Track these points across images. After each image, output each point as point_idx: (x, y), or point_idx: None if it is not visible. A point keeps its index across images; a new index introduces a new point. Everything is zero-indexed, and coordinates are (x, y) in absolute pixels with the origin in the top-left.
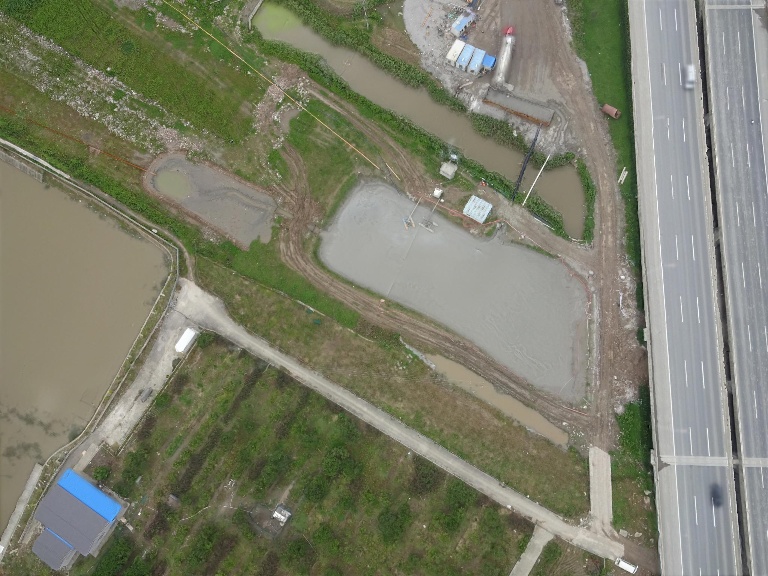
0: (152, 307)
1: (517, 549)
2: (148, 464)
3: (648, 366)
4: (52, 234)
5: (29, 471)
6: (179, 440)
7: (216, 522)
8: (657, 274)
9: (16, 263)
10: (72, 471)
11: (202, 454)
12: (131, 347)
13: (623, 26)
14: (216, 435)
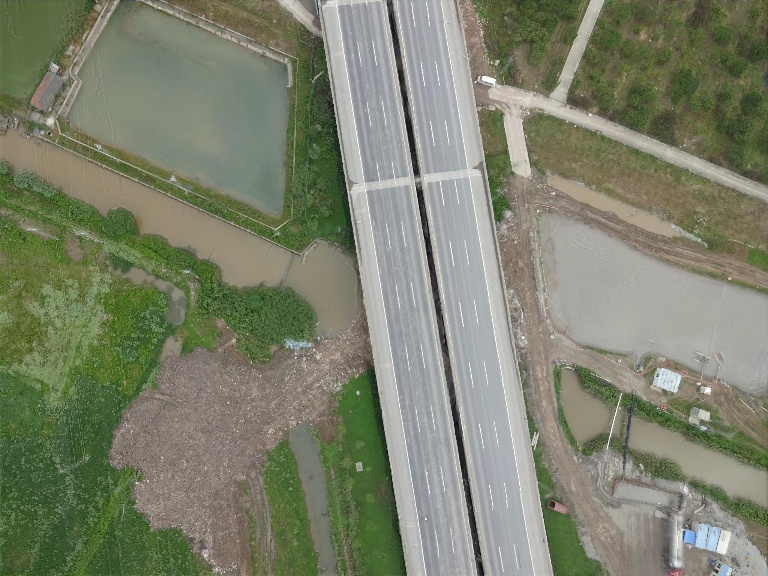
0: None
1: None
2: None
3: None
4: None
5: None
6: None
7: None
8: (501, 343)
9: None
10: None
11: None
12: None
13: None
14: None
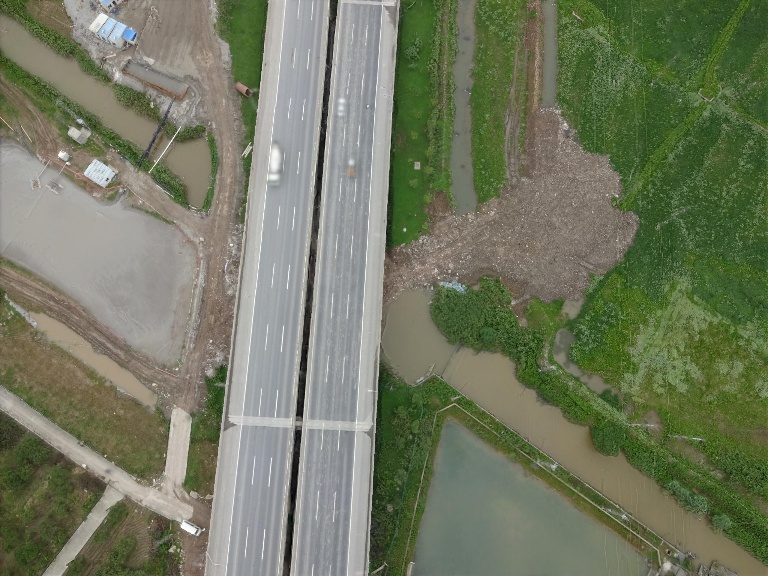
0: None
1: None
2: None
3: None
4: None
5: None
6: None
7: None
8: (256, 242)
9: None
10: None
11: None
12: None
13: (264, 13)
14: None
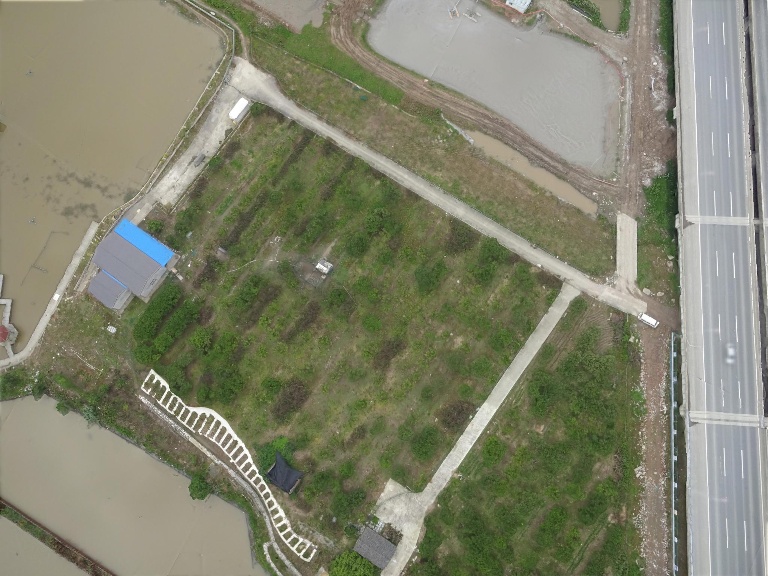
0: (207, 84)
1: (545, 303)
2: (199, 221)
3: (677, 138)
4: (115, 18)
5: (86, 229)
6: (229, 200)
7: (261, 274)
8: (688, 56)
9: (80, 41)
10: (128, 223)
11: (251, 212)
12: (186, 119)
13: None
14: (264, 195)
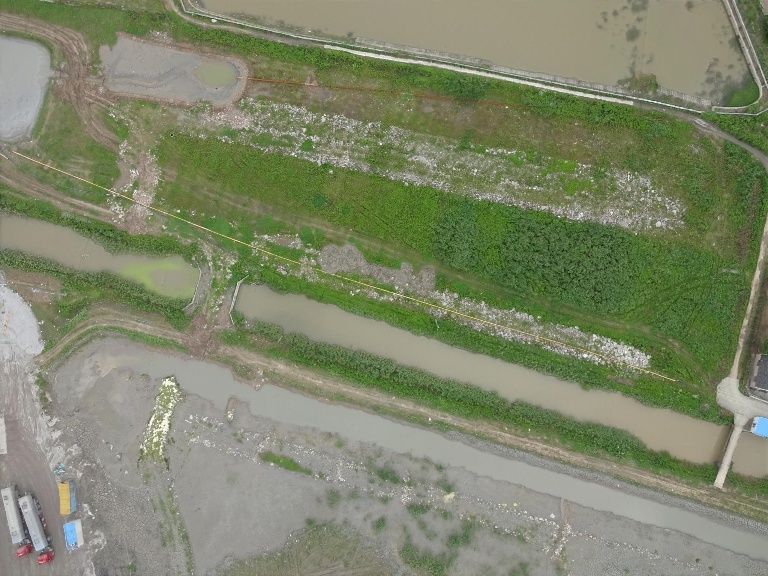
0: None
1: None
2: None
3: None
4: None
5: None
6: None
7: None
8: None
9: None
10: None
11: None
12: None
13: None
14: None
